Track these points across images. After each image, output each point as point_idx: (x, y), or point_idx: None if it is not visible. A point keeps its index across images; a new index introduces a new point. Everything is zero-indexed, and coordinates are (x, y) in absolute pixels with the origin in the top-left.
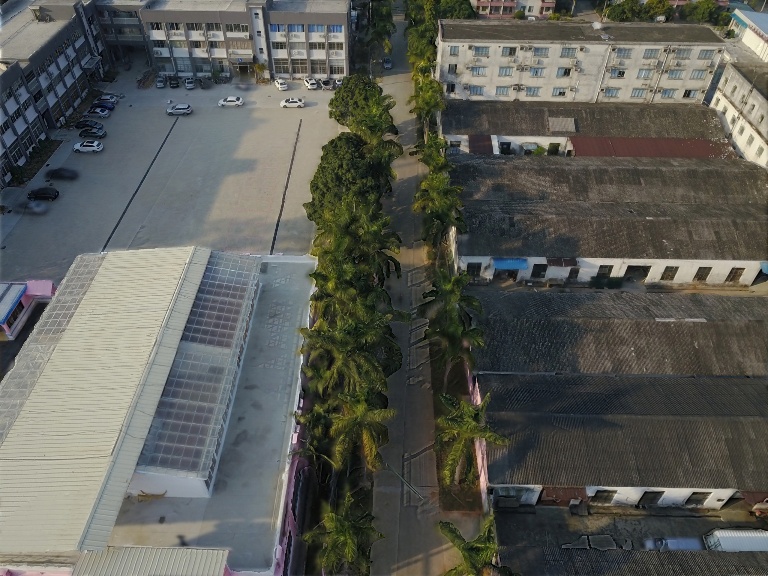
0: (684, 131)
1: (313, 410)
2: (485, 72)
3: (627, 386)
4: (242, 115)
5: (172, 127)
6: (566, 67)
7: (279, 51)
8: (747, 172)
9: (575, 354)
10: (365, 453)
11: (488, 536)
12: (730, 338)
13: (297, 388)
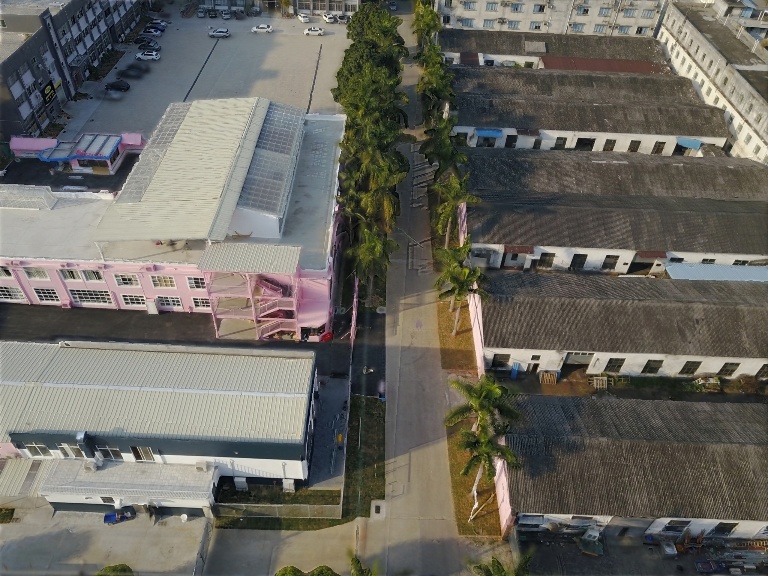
0: (632, 55)
1: (349, 193)
2: (475, 6)
3: (567, 196)
4: (272, 39)
5: (214, 46)
6: (541, 4)
7: None
8: (676, 80)
9: (533, 181)
10: (385, 216)
11: None
12: (644, 174)
13: (335, 187)
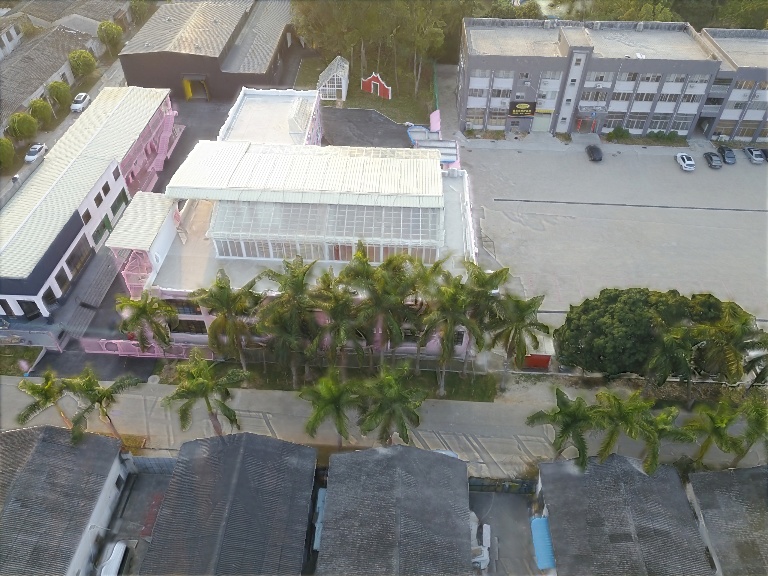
0: None
1: None
2: None
3: None
4: None
5: None
6: None
7: None
8: None
9: None
10: None
11: None
12: None
13: None
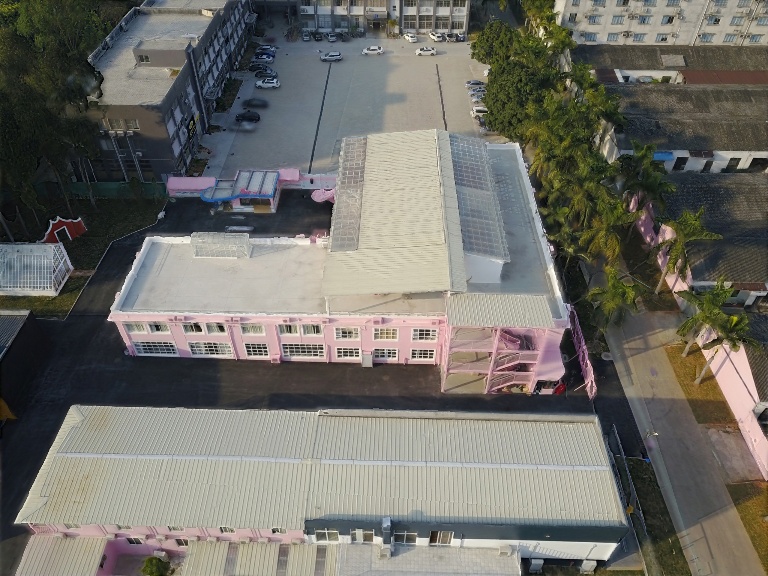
0: None
1: (561, 231)
2: (600, 20)
3: None
4: (385, 61)
5: (329, 70)
6: (670, 15)
7: (409, 8)
8: None
9: (732, 209)
10: (607, 256)
11: (721, 289)
12: None
13: (535, 224)
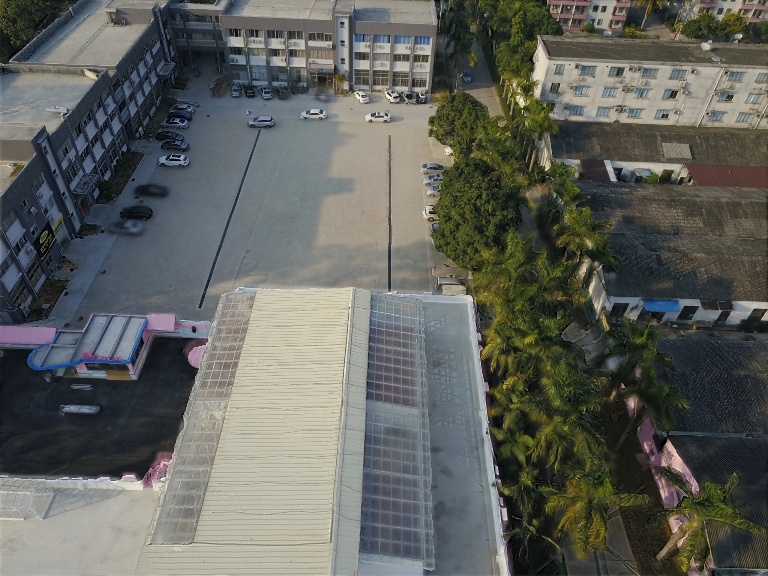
0: None
1: (519, 481)
2: (588, 92)
3: None
4: (327, 129)
5: (256, 140)
6: (673, 89)
7: (361, 62)
8: None
9: (764, 413)
10: None
11: None
12: None
13: (485, 451)
